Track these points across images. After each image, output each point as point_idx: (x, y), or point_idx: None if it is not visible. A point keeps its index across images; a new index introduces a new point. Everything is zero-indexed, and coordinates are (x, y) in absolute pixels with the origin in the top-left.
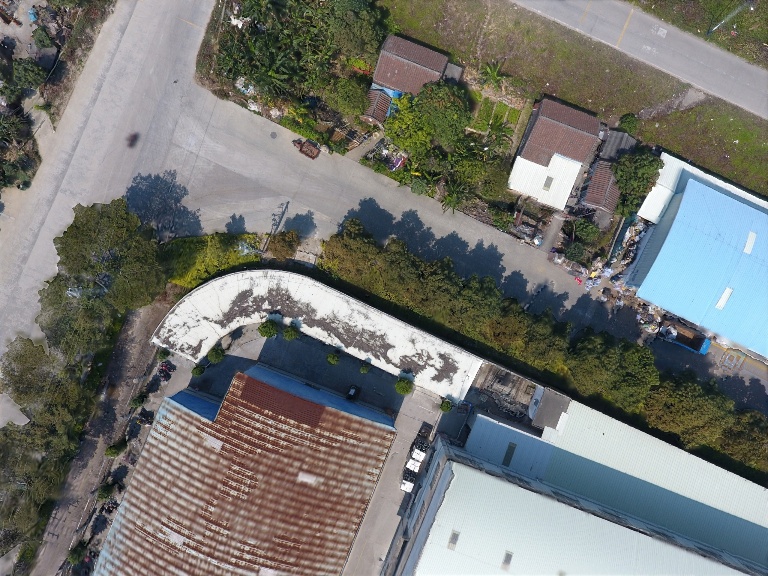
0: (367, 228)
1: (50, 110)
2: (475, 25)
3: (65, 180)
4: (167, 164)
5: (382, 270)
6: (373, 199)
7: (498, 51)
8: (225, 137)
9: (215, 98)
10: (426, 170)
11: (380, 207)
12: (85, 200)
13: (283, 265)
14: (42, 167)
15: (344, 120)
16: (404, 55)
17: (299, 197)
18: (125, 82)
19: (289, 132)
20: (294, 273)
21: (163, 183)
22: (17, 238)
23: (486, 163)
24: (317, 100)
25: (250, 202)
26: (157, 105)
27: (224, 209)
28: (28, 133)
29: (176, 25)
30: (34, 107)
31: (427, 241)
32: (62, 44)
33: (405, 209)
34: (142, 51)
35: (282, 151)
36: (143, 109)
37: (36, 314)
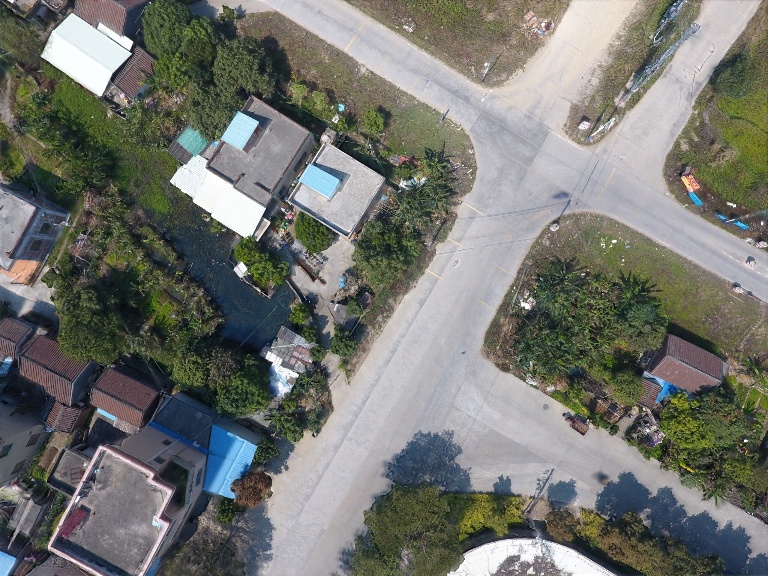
0: (624, 500)
1: (347, 366)
2: (744, 326)
3: (352, 430)
4: (446, 424)
5: (663, 572)
6: (632, 473)
7: (762, 349)
8: (502, 405)
9: (497, 370)
10: (695, 464)
11: (638, 482)
12: (368, 449)
13: (542, 526)
14: (333, 416)
15: (604, 390)
16: (686, 359)
17: (563, 465)
18: (418, 349)
19: (560, 405)
20: (561, 545)
21: (441, 441)
22: (302, 477)
23: (747, 456)
24: (580, 369)
25: (518, 466)
26: (444, 371)
27: (493, 470)
28: (325, 385)
29: (471, 303)
30: (338, 367)
31: (679, 517)
32: (364, 308)
33: (661, 486)
34: (437, 323)
35: (552, 422)
36: (431, 374)
37: (312, 549)
